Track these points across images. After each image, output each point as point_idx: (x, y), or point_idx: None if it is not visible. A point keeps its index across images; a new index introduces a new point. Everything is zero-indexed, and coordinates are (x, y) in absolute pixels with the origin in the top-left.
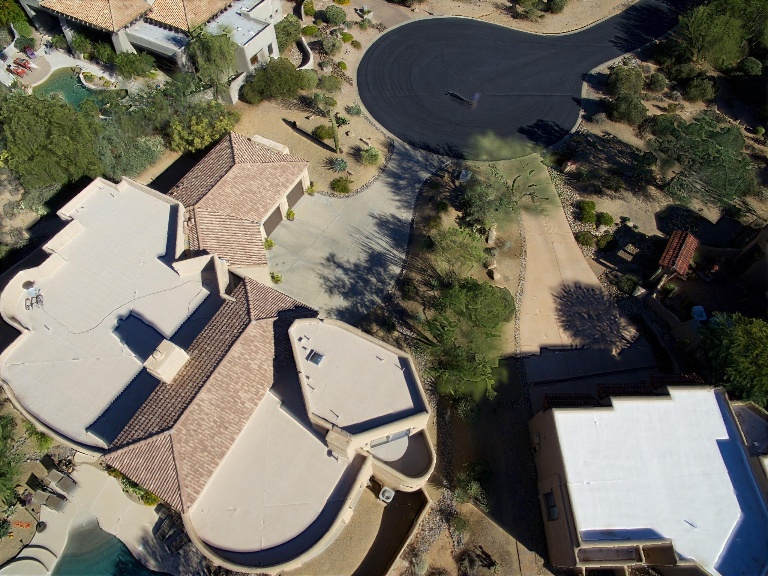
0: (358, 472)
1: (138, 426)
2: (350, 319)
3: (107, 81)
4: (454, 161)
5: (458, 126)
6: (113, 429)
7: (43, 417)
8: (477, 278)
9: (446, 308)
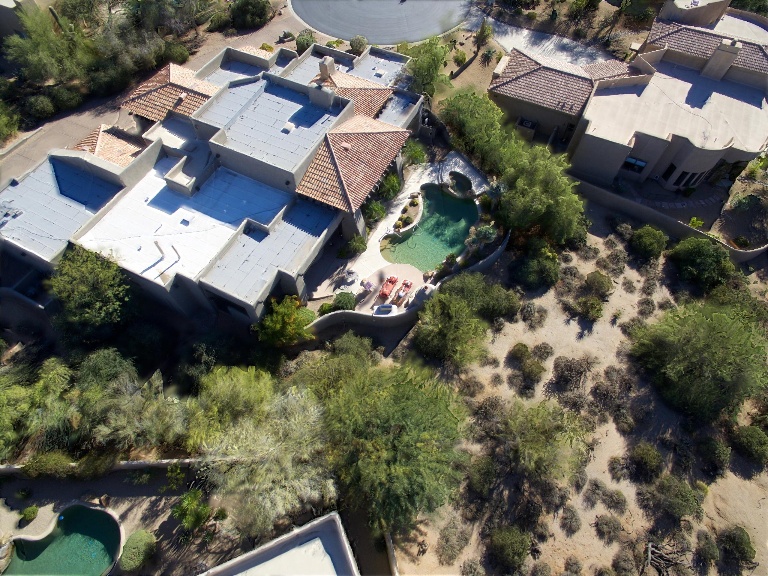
0: (728, 8)
1: (761, 65)
2: (609, 57)
3: (415, 200)
4: (475, 5)
5: (439, 1)
6: (755, 98)
7: (767, 128)
8: (566, 7)
9: (595, 14)
